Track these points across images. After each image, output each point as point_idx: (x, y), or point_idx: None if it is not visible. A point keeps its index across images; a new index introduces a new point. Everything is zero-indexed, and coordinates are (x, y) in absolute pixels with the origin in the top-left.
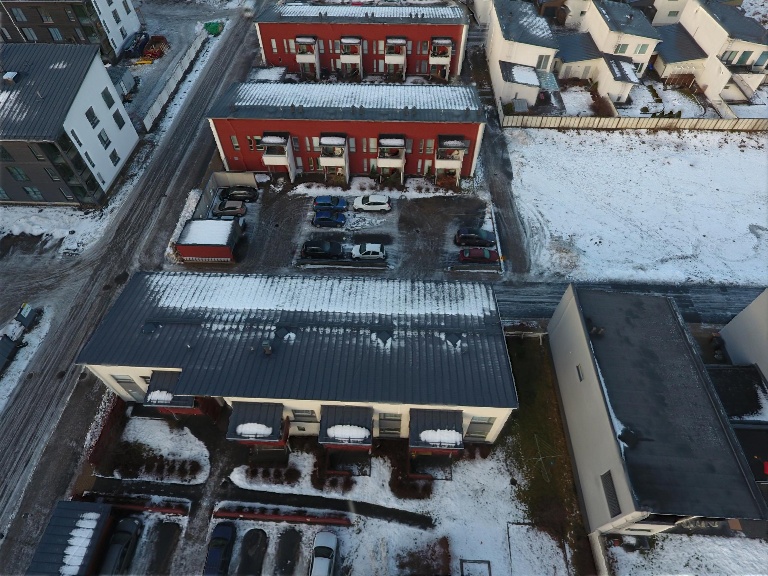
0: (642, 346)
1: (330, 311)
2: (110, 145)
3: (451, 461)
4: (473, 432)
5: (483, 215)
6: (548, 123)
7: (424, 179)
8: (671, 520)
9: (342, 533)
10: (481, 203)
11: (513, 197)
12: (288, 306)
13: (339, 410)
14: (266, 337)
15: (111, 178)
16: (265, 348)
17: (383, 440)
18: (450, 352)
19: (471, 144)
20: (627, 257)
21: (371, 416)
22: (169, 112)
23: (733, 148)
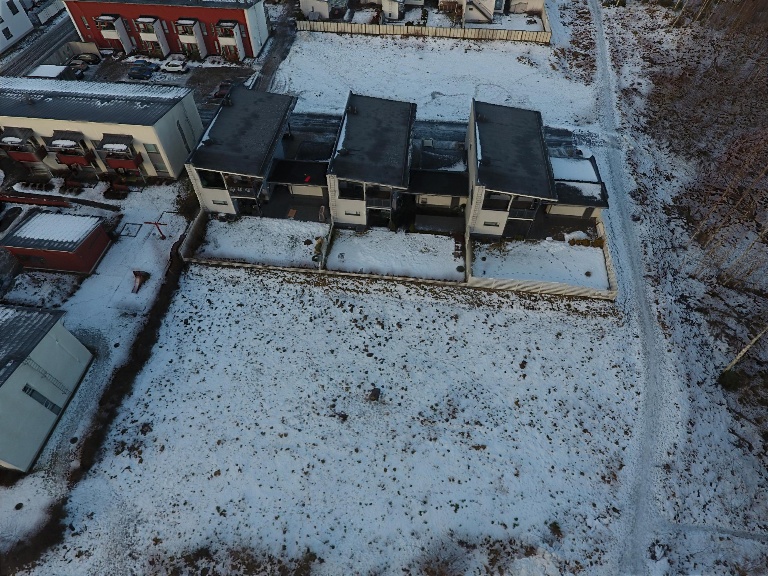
0: (253, 112)
1: (82, 92)
2: (3, 23)
3: (146, 185)
4: (161, 169)
5: (249, 78)
6: (329, 28)
7: (220, 57)
8: (224, 186)
9: (65, 210)
10: (252, 71)
11: (277, 69)
12: (59, 90)
13: (64, 134)
14: (35, 99)
15: (3, 47)
16: (26, 98)
17: (110, 174)
18: (136, 108)
19: (245, 28)
20: (332, 103)
21: (80, 137)
22: (63, 14)
23: (460, 50)
